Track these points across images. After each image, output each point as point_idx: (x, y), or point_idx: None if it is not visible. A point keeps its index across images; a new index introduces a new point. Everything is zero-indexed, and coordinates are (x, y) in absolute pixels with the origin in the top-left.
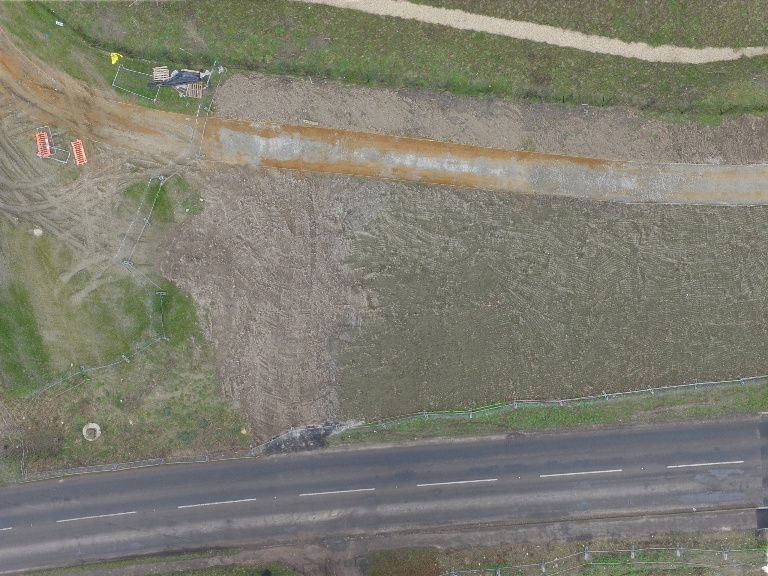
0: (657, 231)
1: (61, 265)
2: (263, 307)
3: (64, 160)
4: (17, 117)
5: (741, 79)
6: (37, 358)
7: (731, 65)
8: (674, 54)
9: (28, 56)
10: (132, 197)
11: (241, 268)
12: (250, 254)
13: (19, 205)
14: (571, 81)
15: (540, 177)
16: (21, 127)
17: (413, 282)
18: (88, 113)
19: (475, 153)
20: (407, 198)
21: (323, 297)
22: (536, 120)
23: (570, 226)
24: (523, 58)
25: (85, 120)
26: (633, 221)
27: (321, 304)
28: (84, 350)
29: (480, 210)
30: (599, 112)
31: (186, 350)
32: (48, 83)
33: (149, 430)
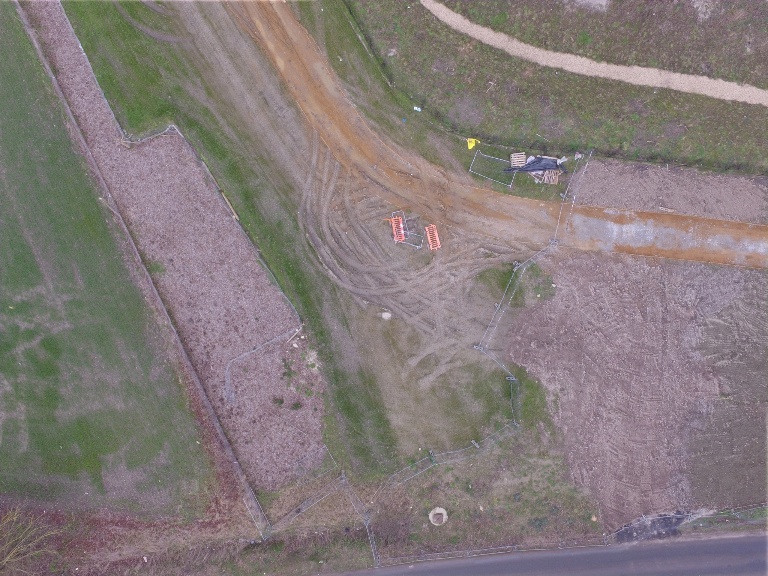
0: None
1: (409, 349)
2: (613, 393)
3: (419, 245)
4: (370, 201)
5: None
6: (385, 442)
7: None
8: None
9: (384, 141)
10: (484, 282)
11: (592, 354)
12: (601, 340)
13: (369, 288)
14: None
15: None
16: (374, 211)
17: (764, 370)
18: (443, 198)
19: None
20: (761, 286)
21: (674, 384)
22: None
23: None
24: None
25: (441, 205)
26: None
27: (672, 391)
28: (432, 434)
29: None
30: None
31: (535, 436)
32: (403, 168)
33: (500, 516)
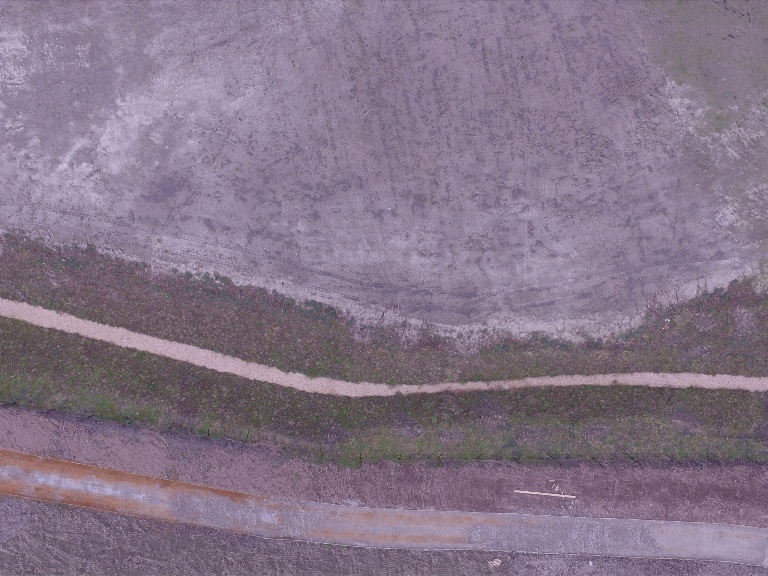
0: (291, 569)
1: None
2: None
3: None
4: None
5: (382, 426)
6: None
7: (383, 404)
8: (331, 386)
9: None
10: None
11: None
12: None
13: None
14: (217, 415)
15: (182, 506)
16: None
17: None
18: None
19: (119, 477)
20: (47, 519)
21: None
22: (181, 450)
23: (207, 557)
24: (176, 385)
25: None
26: (269, 557)
27: None
28: None
29: (119, 535)
30: (243, 447)
31: None
32: None
33: None
